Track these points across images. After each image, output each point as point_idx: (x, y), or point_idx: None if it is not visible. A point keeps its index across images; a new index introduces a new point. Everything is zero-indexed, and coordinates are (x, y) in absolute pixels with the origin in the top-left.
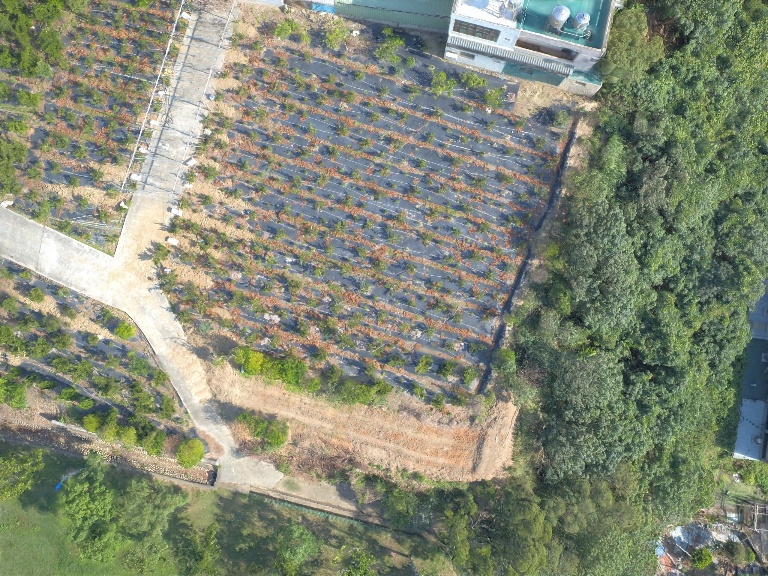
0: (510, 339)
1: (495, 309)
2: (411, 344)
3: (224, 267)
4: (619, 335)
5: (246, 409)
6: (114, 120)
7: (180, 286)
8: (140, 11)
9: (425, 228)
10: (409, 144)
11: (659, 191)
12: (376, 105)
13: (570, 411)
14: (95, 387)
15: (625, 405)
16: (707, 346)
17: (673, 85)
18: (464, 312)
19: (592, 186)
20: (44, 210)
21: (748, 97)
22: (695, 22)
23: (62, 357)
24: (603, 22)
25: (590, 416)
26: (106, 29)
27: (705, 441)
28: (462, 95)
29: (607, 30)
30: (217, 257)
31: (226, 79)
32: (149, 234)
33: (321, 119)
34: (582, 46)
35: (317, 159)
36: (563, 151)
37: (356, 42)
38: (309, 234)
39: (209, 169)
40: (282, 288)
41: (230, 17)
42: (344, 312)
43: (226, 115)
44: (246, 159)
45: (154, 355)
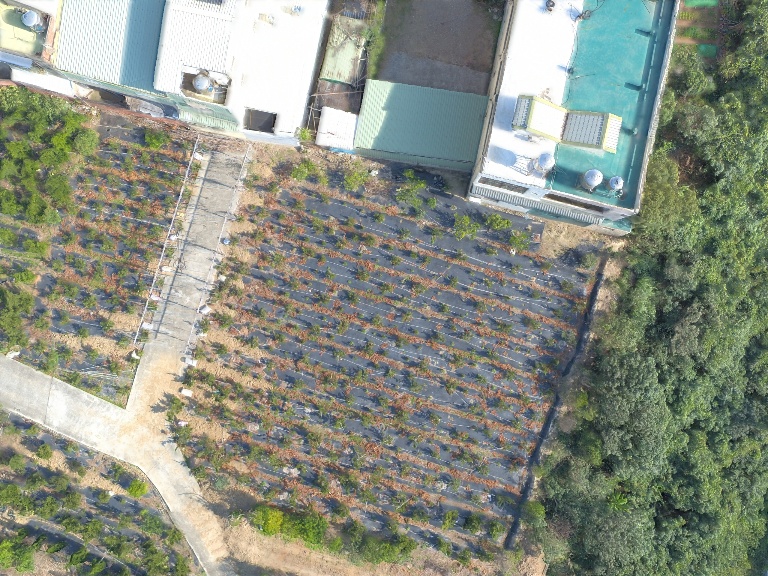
0: (539, 492)
1: (523, 459)
2: (436, 496)
3: (241, 418)
4: (651, 481)
5: (265, 568)
6: (124, 266)
7: (195, 439)
8: (150, 151)
9: (449, 375)
10: (431, 288)
11: (692, 340)
12: (396, 247)
13: (603, 568)
14: (107, 545)
15: (658, 554)
16: (738, 481)
17: (702, 225)
18: (491, 463)
19: (622, 334)
20: (52, 361)
21: None
22: (725, 163)
23: (72, 516)
24: (635, 179)
25: (624, 574)
26: (115, 170)
27: (736, 574)
28: (485, 236)
29: (640, 189)
30: (233, 408)
31: (240, 222)
32: (162, 385)
33: (340, 263)
34: (614, 206)
35: (336, 305)
36: (590, 293)
37: (375, 182)
38: (329, 383)
39: (224, 317)
40: (301, 440)
41: (244, 161)
42: (366, 464)
43: (241, 259)
44: (262, 306)
45: (168, 511)
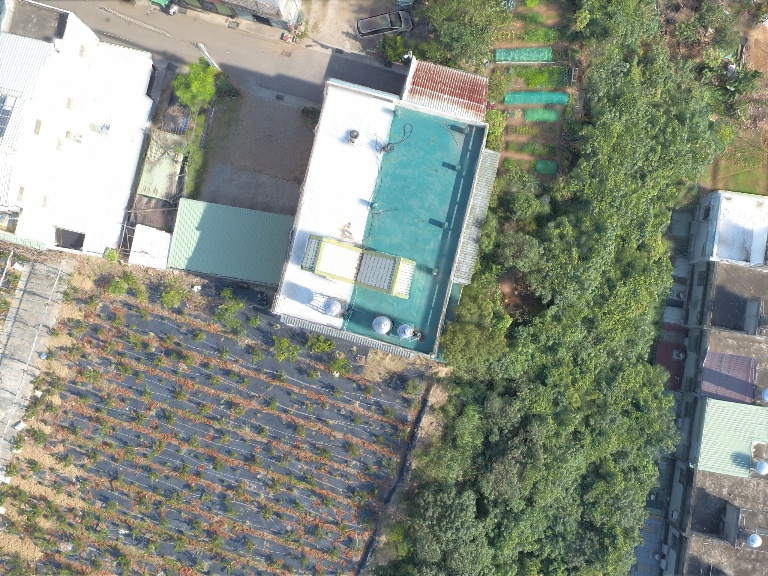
0: None
1: None
2: None
3: (53, 538)
4: None
5: None
6: None
7: (7, 558)
8: None
9: (266, 500)
10: (251, 409)
11: (510, 476)
12: (217, 366)
13: None
14: None
15: None
16: None
17: (532, 351)
18: None
19: (440, 467)
20: None
21: (622, 348)
22: (553, 291)
23: None
24: (435, 321)
25: None
26: None
27: None
28: (308, 357)
29: (437, 333)
30: (47, 526)
31: (59, 336)
32: None
33: (158, 381)
34: (410, 351)
35: (153, 424)
36: (415, 419)
37: (197, 298)
38: (143, 504)
39: (38, 435)
40: (114, 562)
41: None
42: None
43: (59, 374)
44: (78, 423)
45: None
